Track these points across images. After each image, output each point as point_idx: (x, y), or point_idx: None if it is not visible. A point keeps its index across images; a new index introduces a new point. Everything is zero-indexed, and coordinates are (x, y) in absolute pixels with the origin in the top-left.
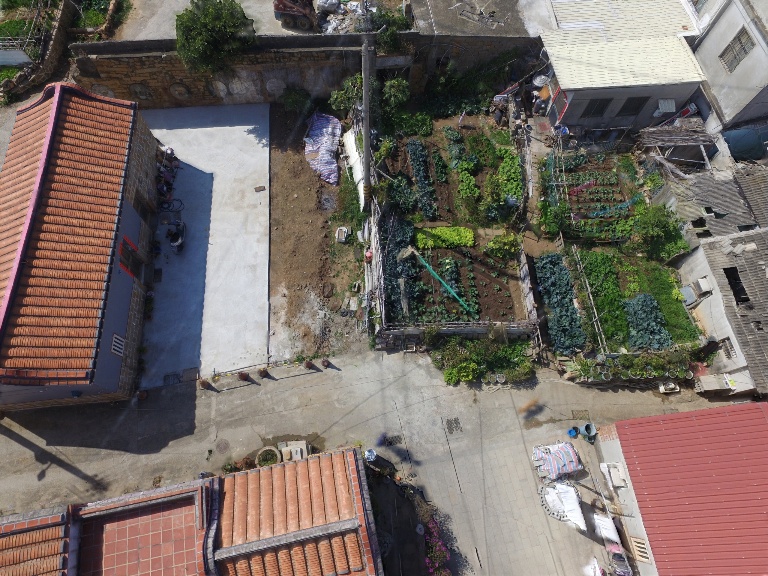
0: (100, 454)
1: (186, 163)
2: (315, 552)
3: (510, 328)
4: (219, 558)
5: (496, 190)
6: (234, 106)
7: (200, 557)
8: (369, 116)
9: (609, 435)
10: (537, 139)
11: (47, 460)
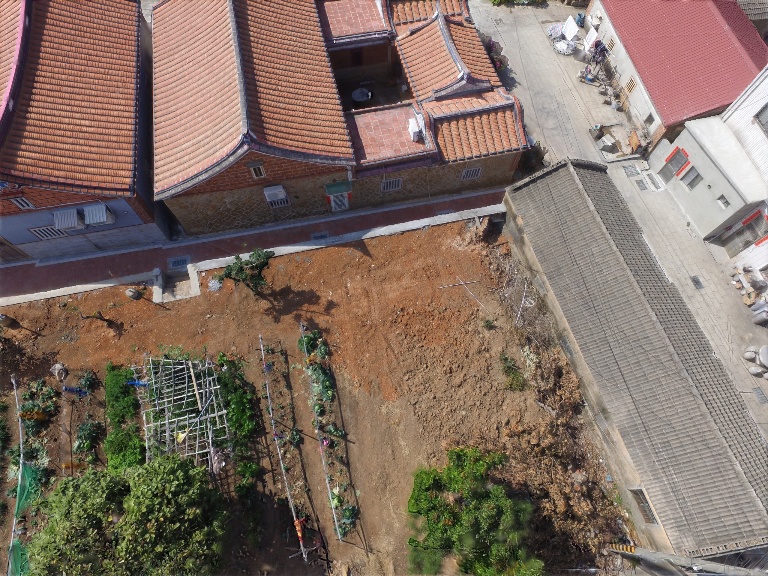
0: None
1: None
2: None
3: None
4: None
5: None
6: None
7: None
8: None
9: (591, 5)
10: None
11: None
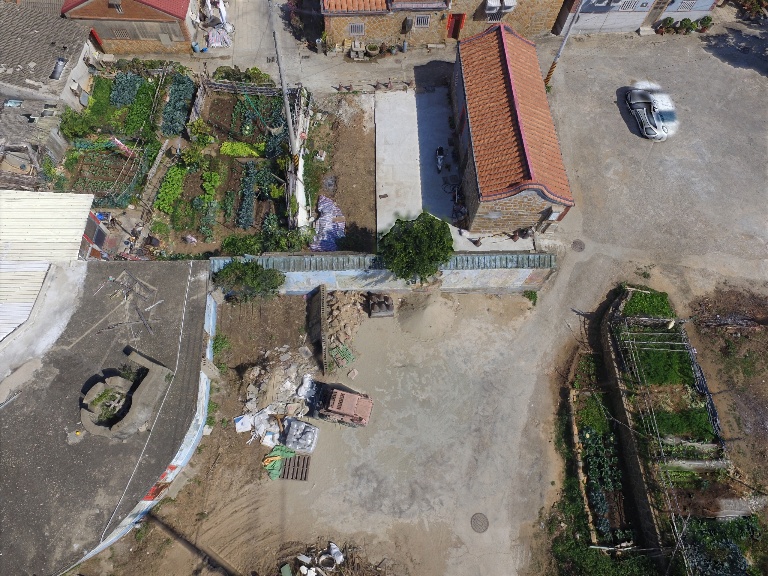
0: None
1: None
2: None
3: None
4: None
5: (193, 149)
6: None
7: None
8: None
9: None
10: (125, 231)
11: None
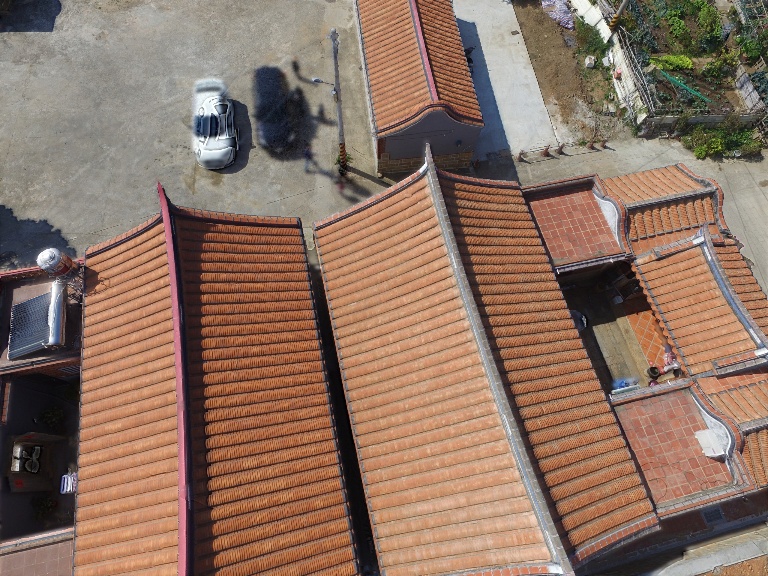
0: None
1: None
2: (684, 210)
3: (743, 115)
4: (629, 207)
5: (714, 21)
6: None
7: (620, 203)
8: None
9: None
10: None
11: None
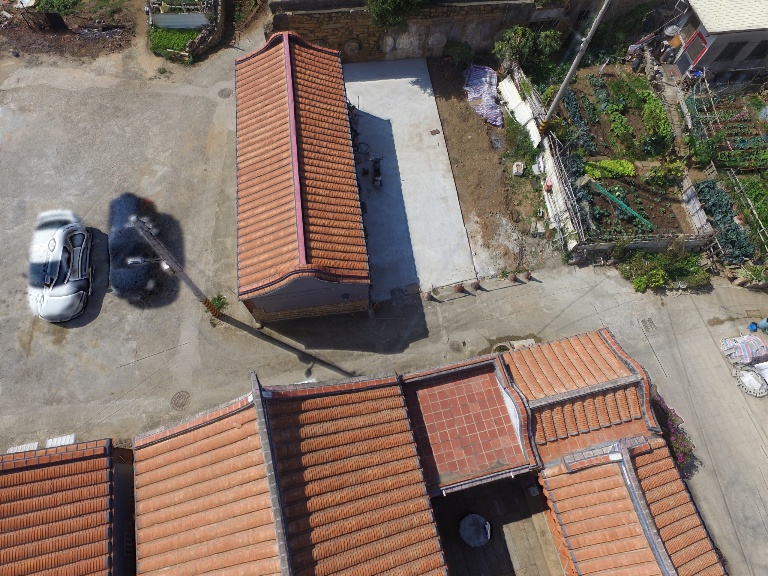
0: (353, 355)
1: (364, 112)
2: (603, 403)
3: (688, 240)
4: (533, 406)
5: (658, 123)
6: (394, 61)
7: (521, 404)
8: (523, 65)
9: None
10: (669, 84)
11: (309, 361)
